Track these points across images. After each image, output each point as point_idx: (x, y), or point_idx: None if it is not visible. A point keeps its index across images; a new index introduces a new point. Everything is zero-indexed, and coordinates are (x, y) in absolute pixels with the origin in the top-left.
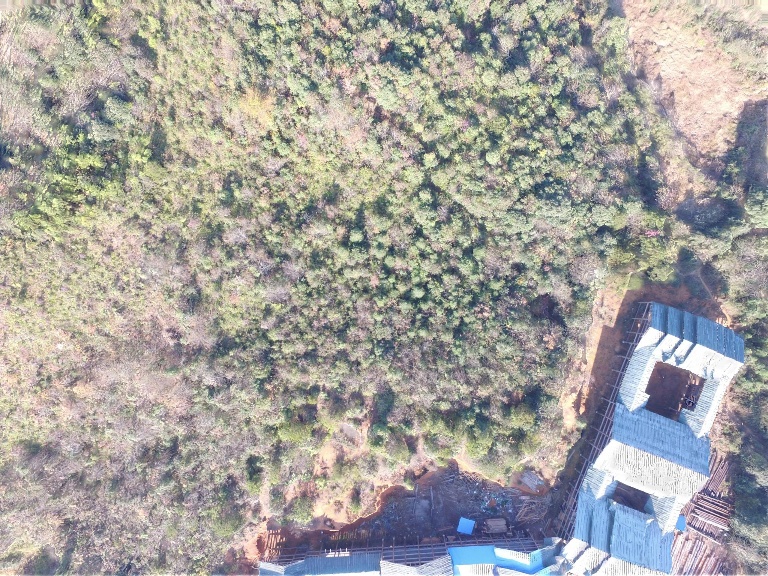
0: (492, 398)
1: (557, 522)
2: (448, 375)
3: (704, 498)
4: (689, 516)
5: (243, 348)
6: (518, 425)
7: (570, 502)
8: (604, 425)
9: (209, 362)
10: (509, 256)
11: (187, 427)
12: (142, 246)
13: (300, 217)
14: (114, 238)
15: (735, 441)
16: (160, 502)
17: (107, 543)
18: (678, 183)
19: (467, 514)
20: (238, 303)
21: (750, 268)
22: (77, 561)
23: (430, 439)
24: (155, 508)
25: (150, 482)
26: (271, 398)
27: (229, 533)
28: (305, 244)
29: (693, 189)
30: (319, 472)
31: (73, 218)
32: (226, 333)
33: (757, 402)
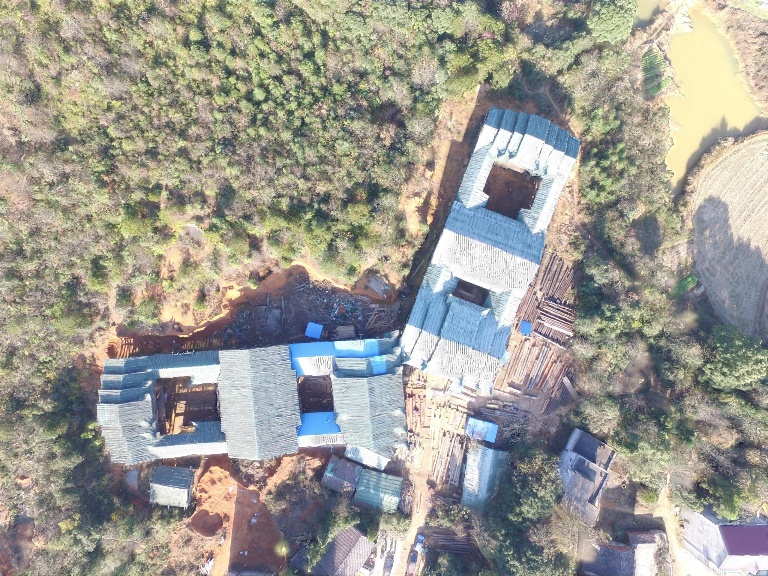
0: (333, 196)
1: None
2: (286, 170)
3: (549, 304)
4: (535, 323)
5: (83, 144)
6: (356, 220)
7: None
8: None
9: (48, 156)
10: (350, 59)
11: (29, 225)
12: None
13: (140, 17)
14: None
15: (579, 249)
16: (3, 300)
17: None
18: (528, 6)
19: (317, 322)
20: (79, 101)
21: (593, 81)
22: None
23: (272, 237)
24: None
25: None
26: (109, 190)
27: (73, 331)
28: (145, 43)
29: (542, 11)
30: (166, 275)
31: None
32: (68, 132)
33: (601, 212)
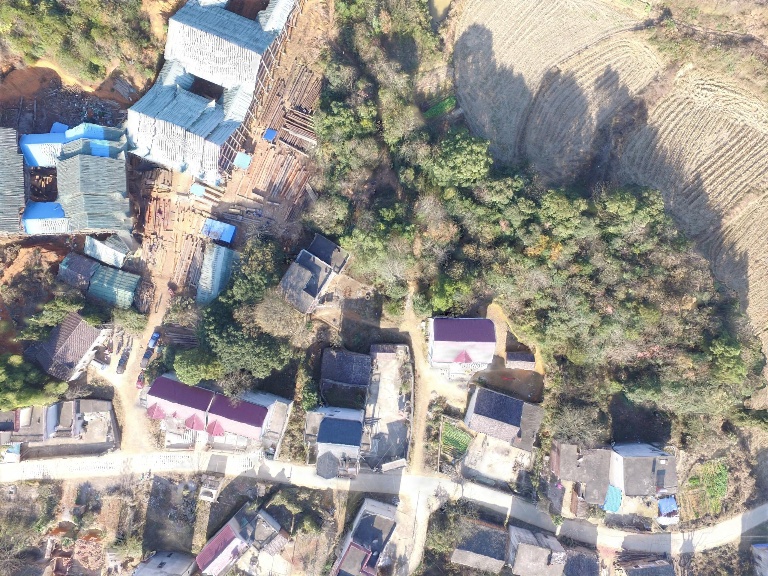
0: None
1: None
2: None
3: (295, 113)
4: (281, 131)
5: None
6: (91, 14)
7: None
8: None
9: None
10: None
11: None
12: None
13: None
14: None
15: (326, 59)
16: None
17: None
18: None
19: None
20: None
21: None
22: None
23: None
24: None
25: None
26: None
27: None
28: None
29: None
30: None
31: None
32: None
33: (351, 25)
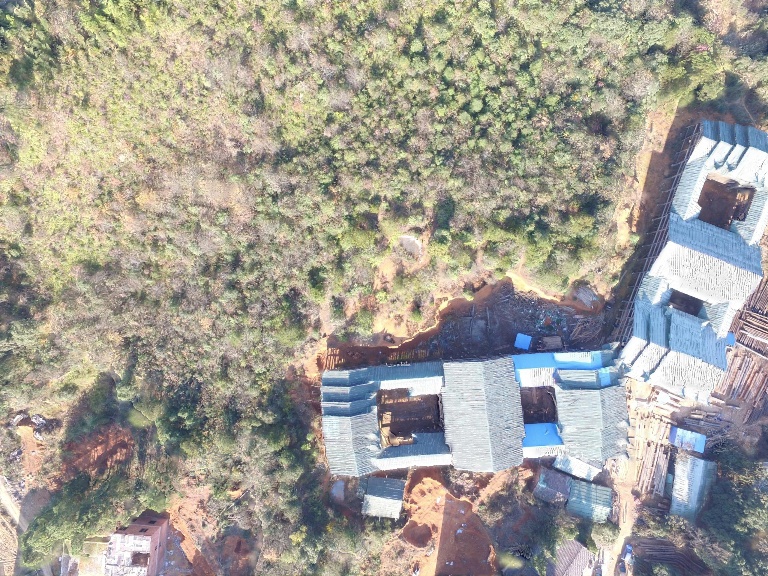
0: (550, 208)
1: (611, 337)
2: (508, 181)
3: (752, 315)
4: (738, 333)
5: (306, 155)
6: (576, 232)
7: (625, 315)
8: (658, 237)
9: (273, 167)
10: (565, 71)
11: (250, 236)
12: (206, 51)
13: (361, 28)
14: (178, 45)
15: None
16: (223, 312)
17: (169, 356)
18: (722, 16)
19: (523, 333)
20: (301, 112)
21: None
22: (139, 376)
23: (490, 249)
24: (218, 318)
25: (213, 293)
26: (335, 202)
27: (292, 342)
28: (366, 54)
29: (736, 22)
30: (379, 287)
31: (137, 22)
32: (288, 143)
33: None
